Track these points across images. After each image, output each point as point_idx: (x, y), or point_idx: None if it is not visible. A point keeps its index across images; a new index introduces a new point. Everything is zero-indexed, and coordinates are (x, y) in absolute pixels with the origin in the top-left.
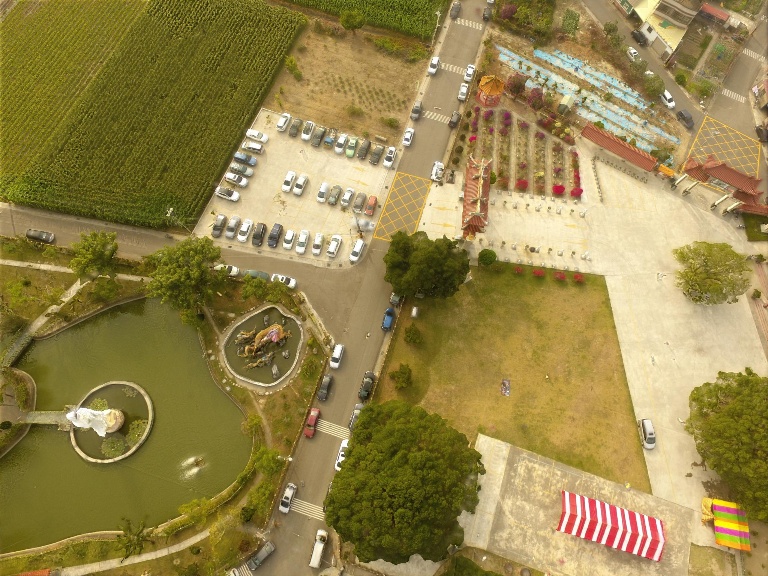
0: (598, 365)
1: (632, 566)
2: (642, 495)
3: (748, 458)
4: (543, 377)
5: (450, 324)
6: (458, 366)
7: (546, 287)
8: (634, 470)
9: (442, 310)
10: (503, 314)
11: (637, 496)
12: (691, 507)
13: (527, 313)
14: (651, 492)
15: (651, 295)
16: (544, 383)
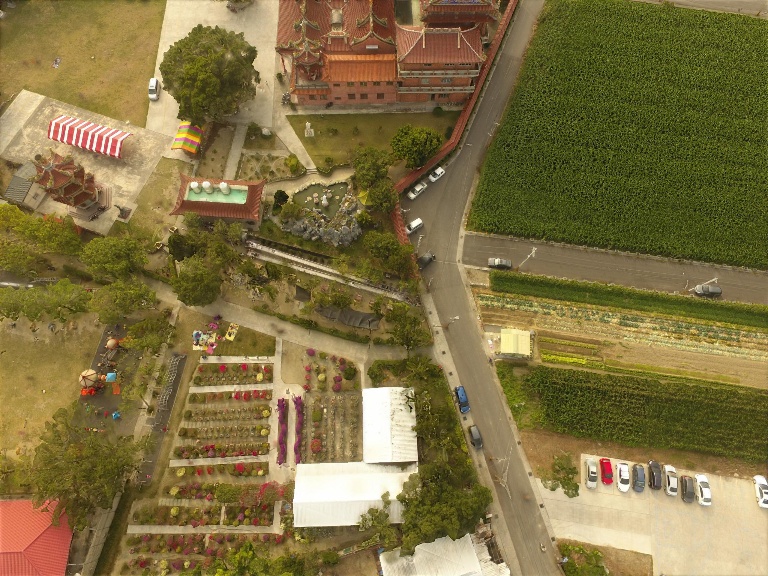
0: (137, 51)
1: (109, 168)
2: (137, 128)
3: (173, 68)
4: (89, 57)
5: (29, 24)
6: (24, 49)
7: (117, 3)
8: (137, 113)
9: (25, 15)
10: (74, 19)
11: (132, 128)
12: (172, 136)
13: (94, 18)
14: (145, 126)
15: (200, 8)
16: (89, 61)
